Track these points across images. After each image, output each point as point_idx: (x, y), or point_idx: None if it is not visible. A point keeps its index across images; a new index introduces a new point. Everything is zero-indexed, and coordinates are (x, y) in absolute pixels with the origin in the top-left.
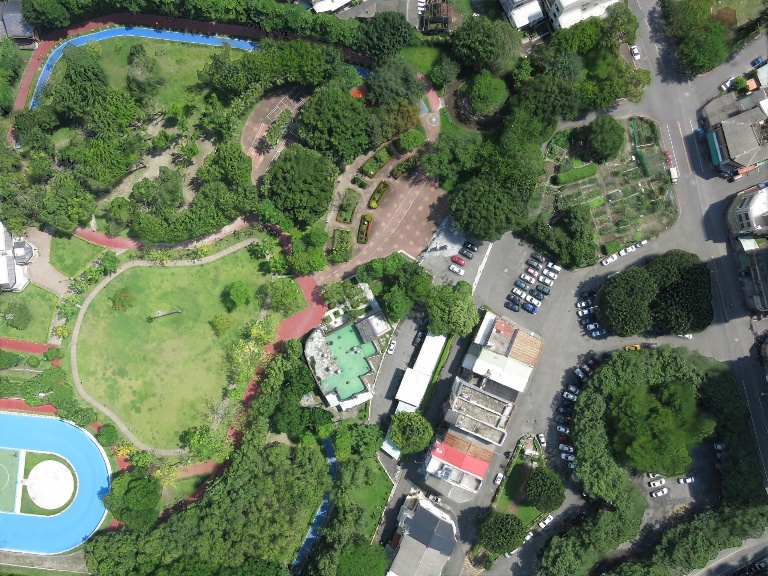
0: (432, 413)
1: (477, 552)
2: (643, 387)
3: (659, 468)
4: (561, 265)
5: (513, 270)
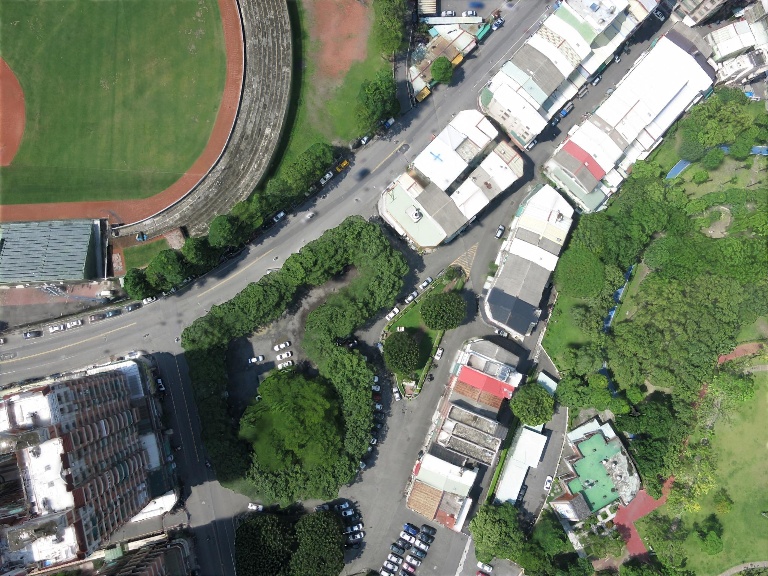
0: (506, 417)
1: (458, 281)
2: (310, 466)
3: (294, 385)
4: (380, 575)
5: (428, 568)
